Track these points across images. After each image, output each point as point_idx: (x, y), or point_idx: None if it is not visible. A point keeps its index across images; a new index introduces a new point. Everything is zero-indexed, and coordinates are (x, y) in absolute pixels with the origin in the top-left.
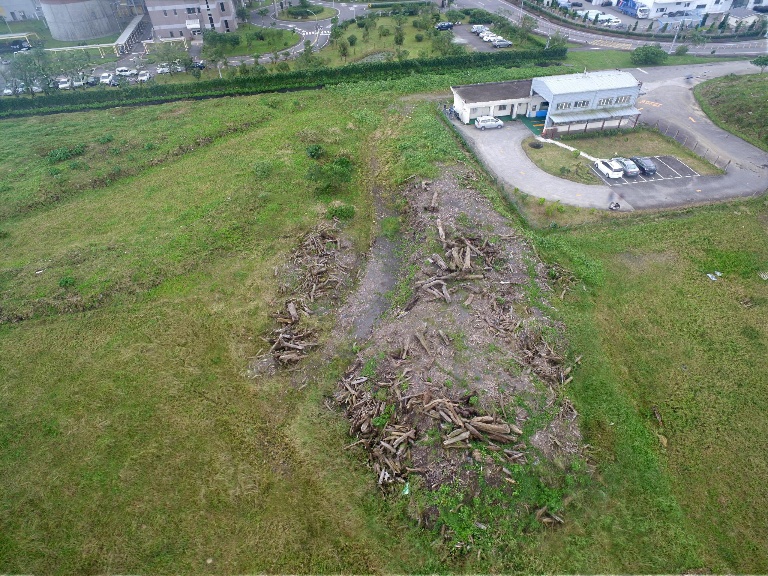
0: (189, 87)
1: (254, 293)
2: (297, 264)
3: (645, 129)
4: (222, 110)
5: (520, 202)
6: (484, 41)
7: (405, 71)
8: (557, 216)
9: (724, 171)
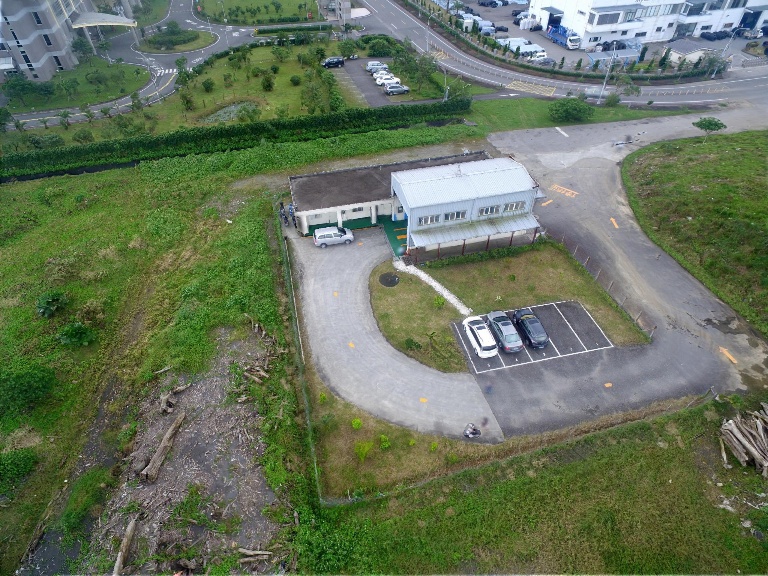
0: None
1: None
2: None
3: (548, 243)
4: None
5: (322, 427)
6: (376, 84)
7: (256, 137)
8: (375, 459)
9: (648, 338)
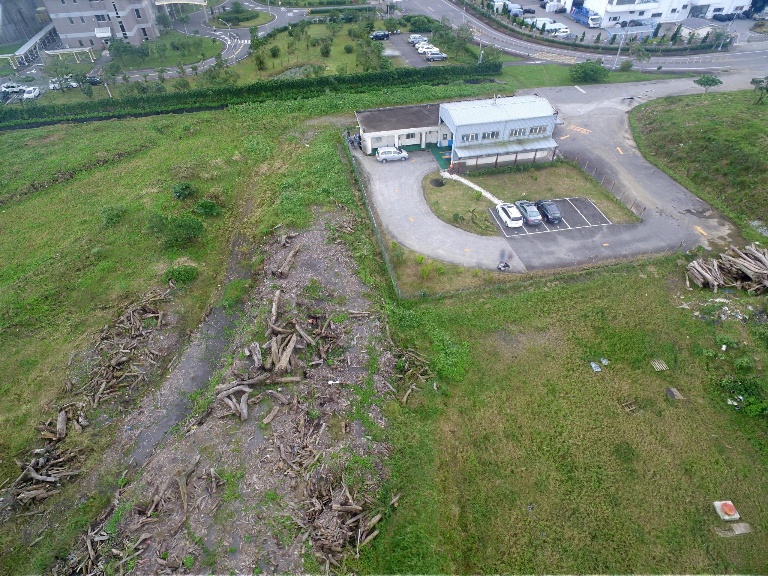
0: (73, 108)
1: (33, 391)
2: (97, 350)
3: (565, 162)
4: (99, 136)
5: (395, 260)
6: (419, 53)
7: (321, 89)
8: (434, 279)
9: (639, 219)
